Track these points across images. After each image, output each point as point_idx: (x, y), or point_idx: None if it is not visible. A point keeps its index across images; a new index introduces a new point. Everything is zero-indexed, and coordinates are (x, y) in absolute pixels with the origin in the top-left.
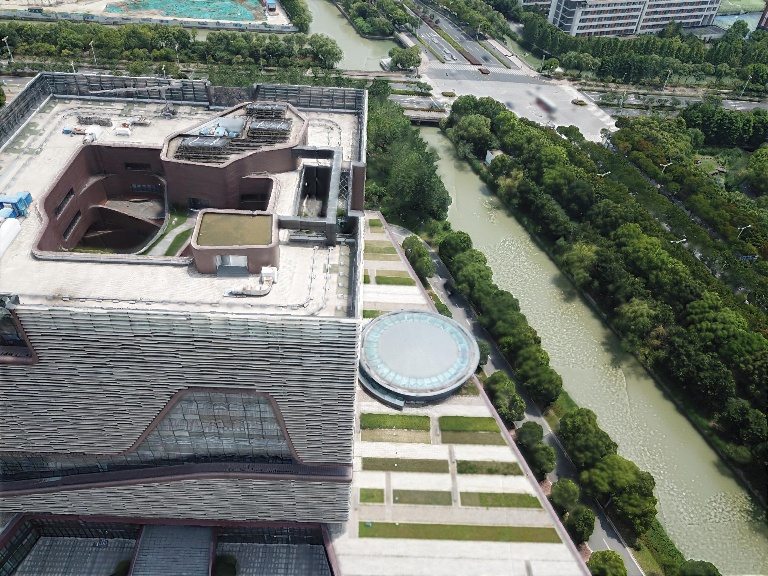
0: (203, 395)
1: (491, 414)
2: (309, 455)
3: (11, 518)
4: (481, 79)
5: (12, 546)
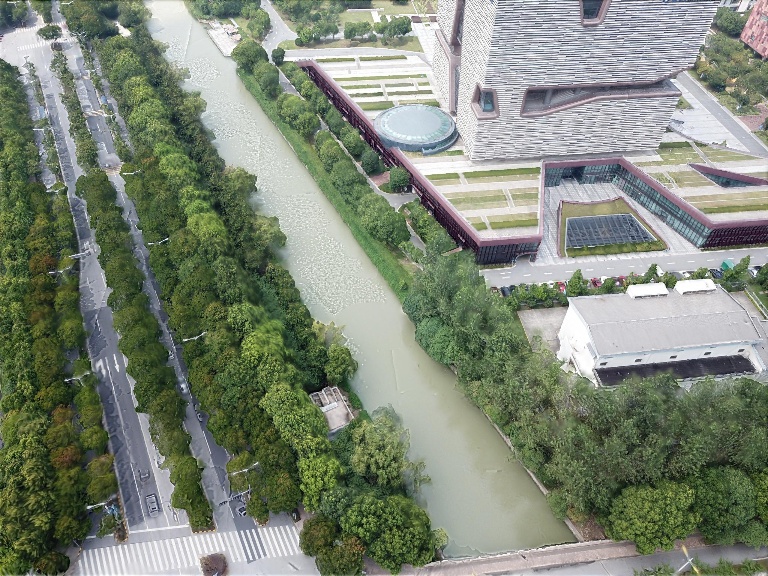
0: None
1: (365, 113)
2: None
3: None
4: None
5: None
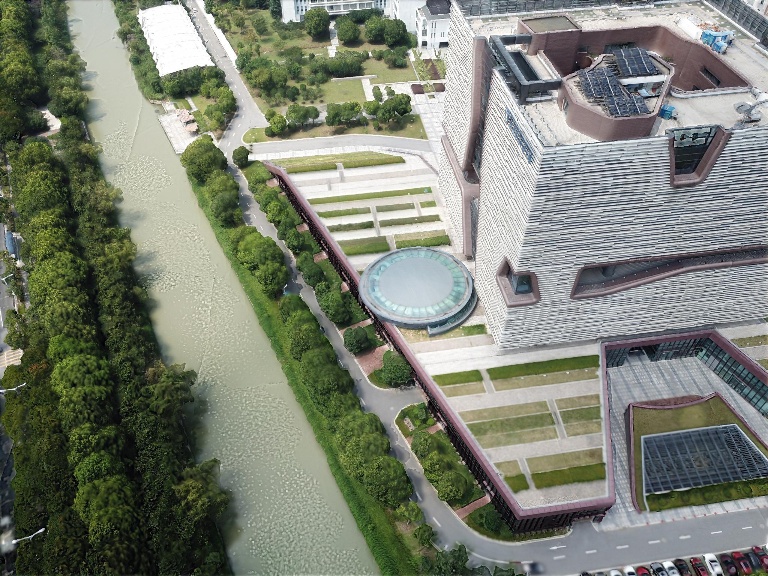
0: None
1: (348, 259)
2: None
3: None
4: None
5: None
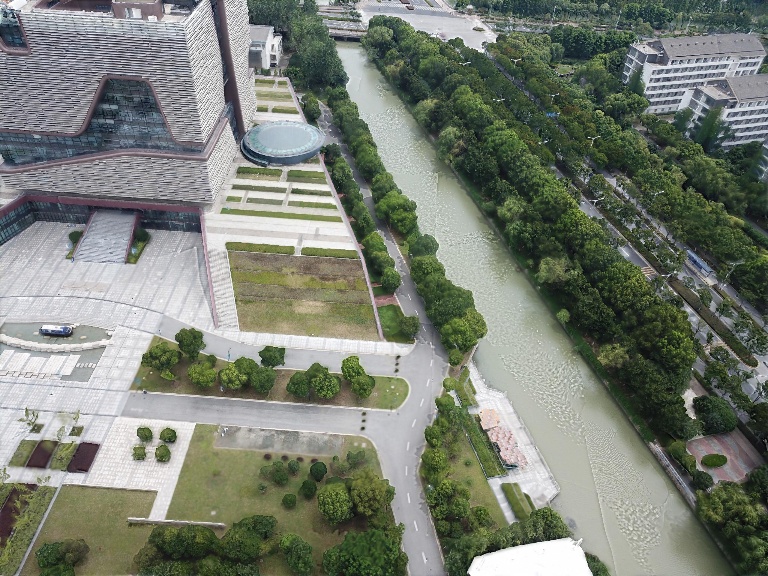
0: (118, 88)
1: None
2: (179, 134)
3: (18, 195)
4: (406, 13)
5: (19, 215)
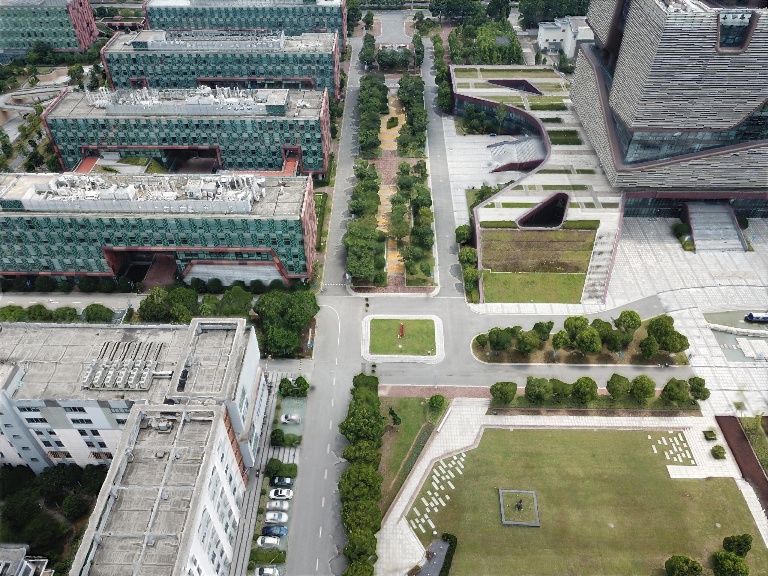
0: None
1: None
2: None
3: None
4: None
5: None
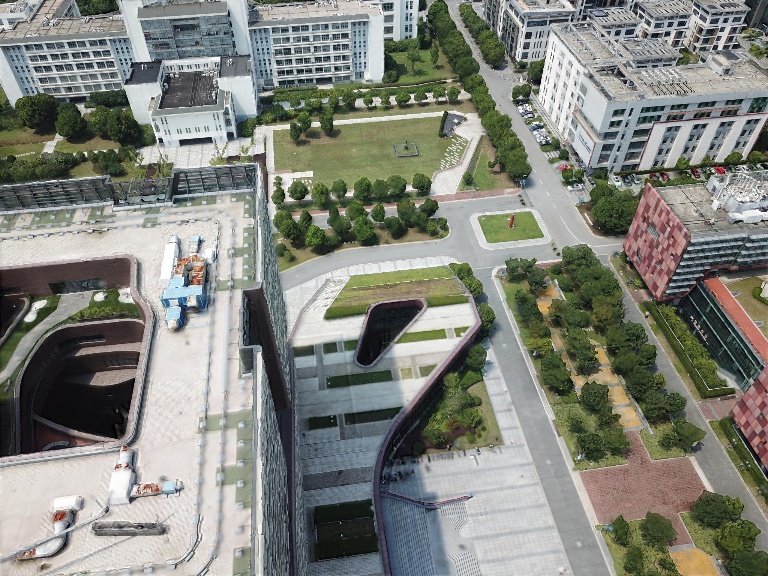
0: None
1: None
2: None
3: None
4: None
5: None
